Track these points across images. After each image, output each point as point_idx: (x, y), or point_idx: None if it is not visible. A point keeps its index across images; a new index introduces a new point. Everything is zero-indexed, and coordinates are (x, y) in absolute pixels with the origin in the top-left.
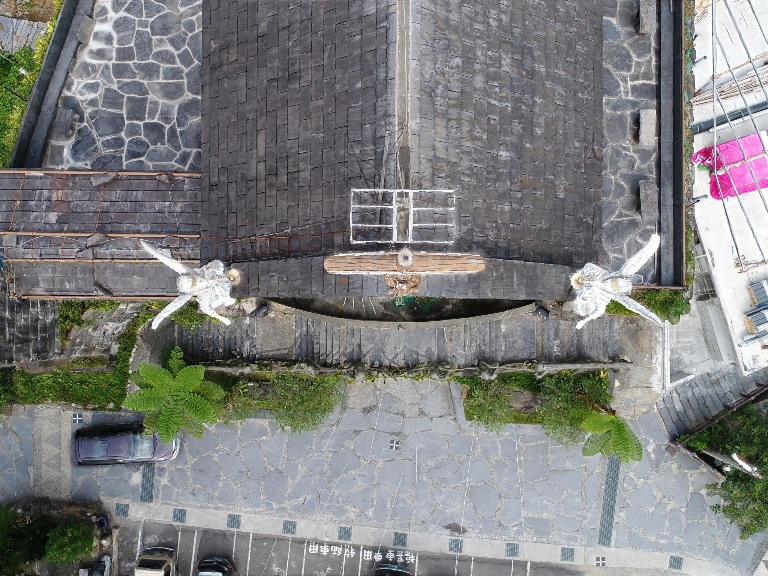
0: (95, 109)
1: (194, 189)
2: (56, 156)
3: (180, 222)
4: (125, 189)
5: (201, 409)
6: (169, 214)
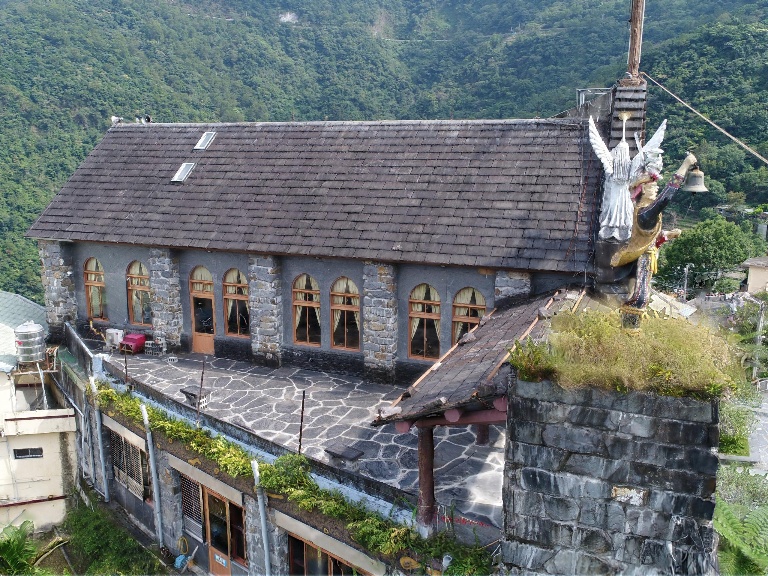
0: None
1: None
2: None
3: None
4: None
5: (767, 517)
6: None
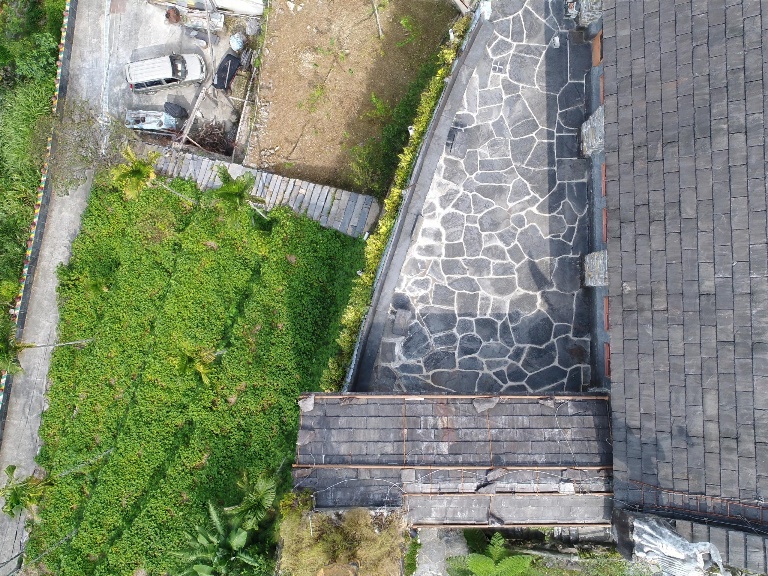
0: (426, 306)
1: (579, 413)
2: (387, 353)
3: (574, 451)
4: (509, 414)
5: None
6: (561, 442)
